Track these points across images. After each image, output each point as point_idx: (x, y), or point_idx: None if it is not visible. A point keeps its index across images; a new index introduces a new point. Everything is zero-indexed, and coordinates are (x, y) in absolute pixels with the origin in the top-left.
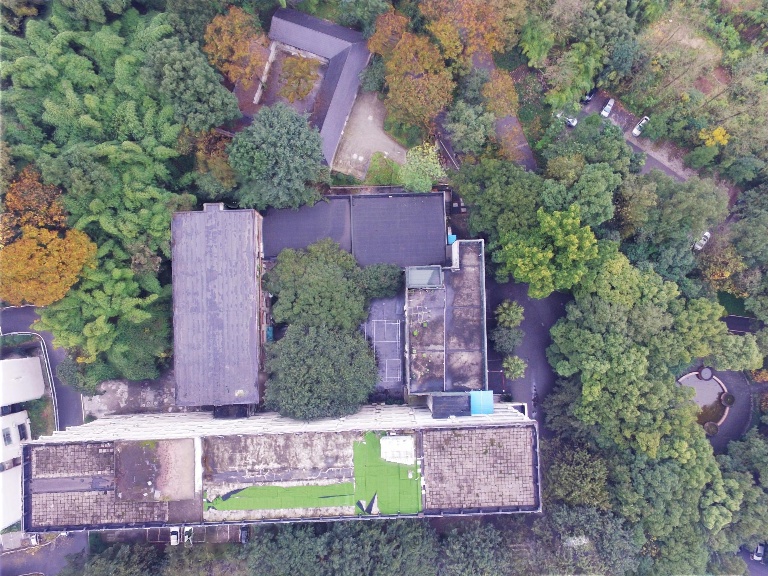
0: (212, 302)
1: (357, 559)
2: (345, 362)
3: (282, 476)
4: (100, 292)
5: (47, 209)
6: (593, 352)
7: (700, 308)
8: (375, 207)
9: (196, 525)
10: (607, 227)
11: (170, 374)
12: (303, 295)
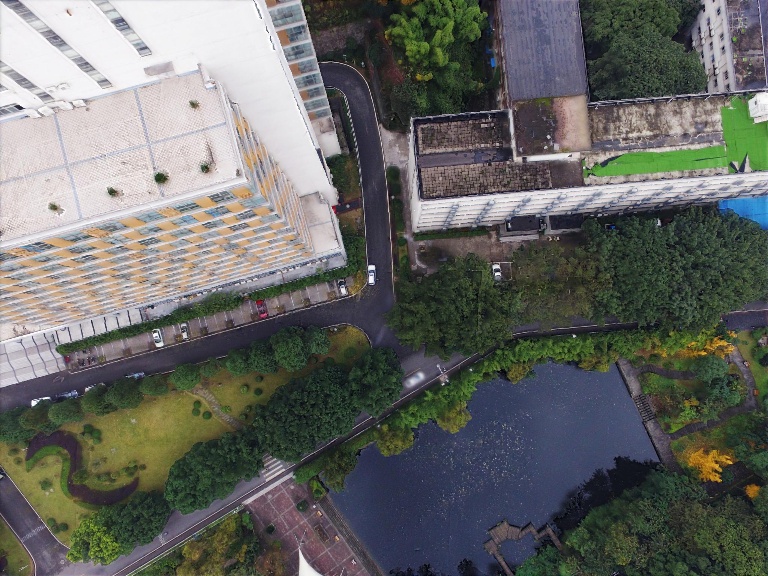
0: (538, 20)
1: None
2: (682, 57)
3: (655, 143)
4: None
5: None
6: None
7: None
8: None
9: None
10: None
11: None
12: (625, 8)
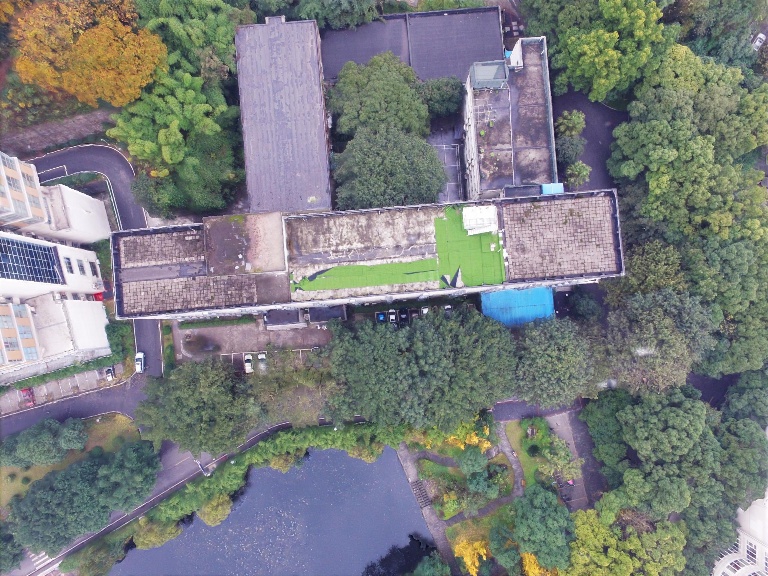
0: (280, 112)
1: (440, 347)
2: (417, 157)
3: (366, 256)
4: (172, 97)
5: (120, 4)
6: (660, 140)
7: (765, 89)
8: (431, 25)
9: (286, 302)
10: (666, 24)
11: (235, 208)
12: (369, 100)
